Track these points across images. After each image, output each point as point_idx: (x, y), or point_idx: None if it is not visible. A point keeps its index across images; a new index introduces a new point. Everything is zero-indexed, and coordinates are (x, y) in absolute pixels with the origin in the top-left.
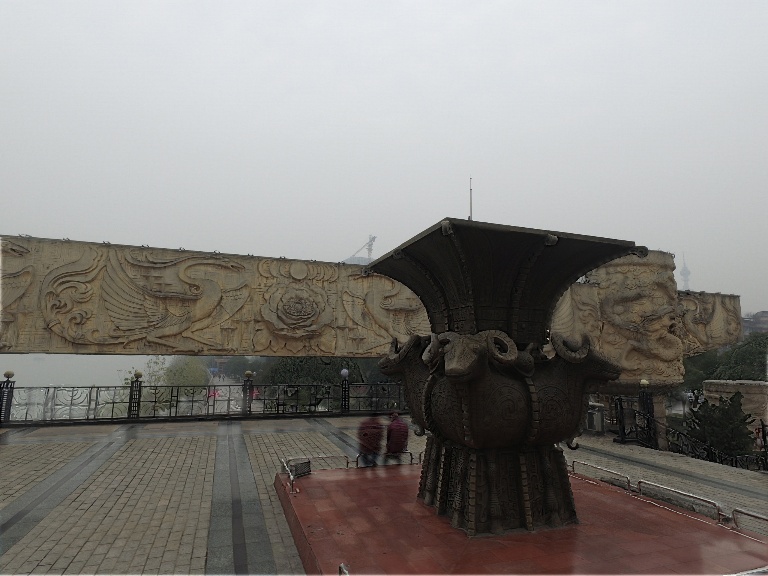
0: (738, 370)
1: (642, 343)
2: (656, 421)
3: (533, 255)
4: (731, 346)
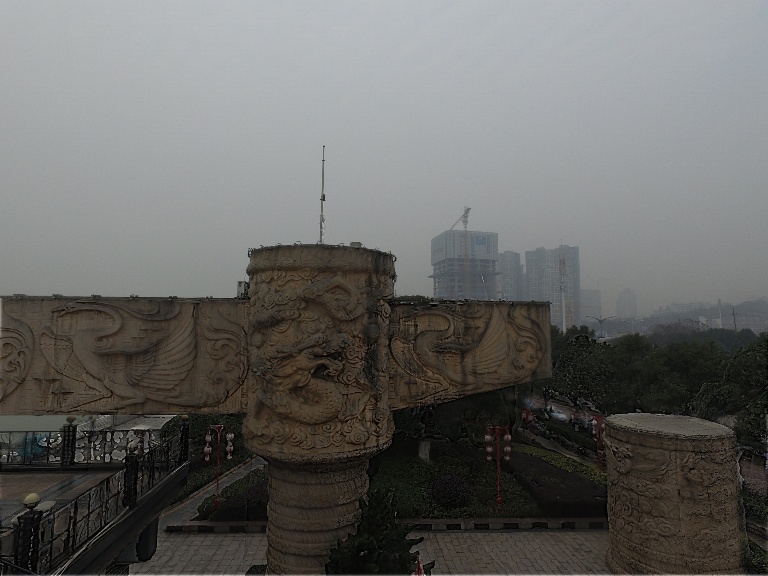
0: (724, 391)
1: (266, 395)
2: (23, 571)
3: None
4: (737, 351)
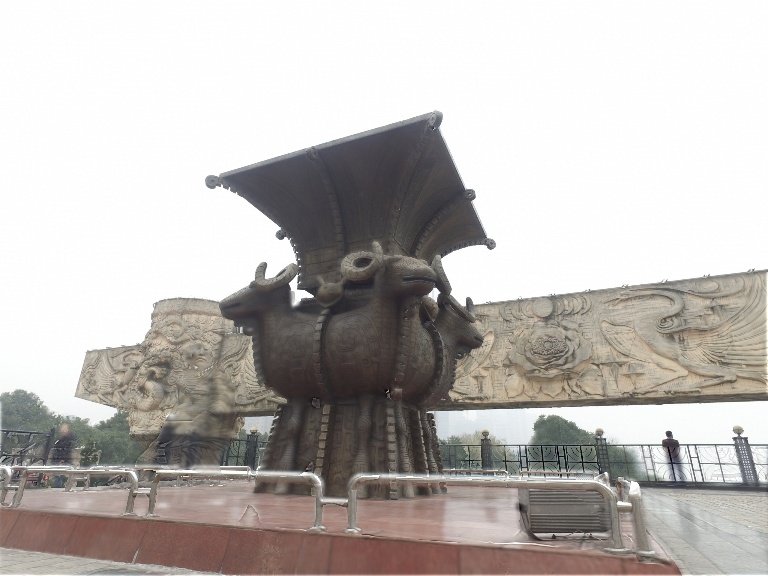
0: None
1: None
2: None
3: None
4: None
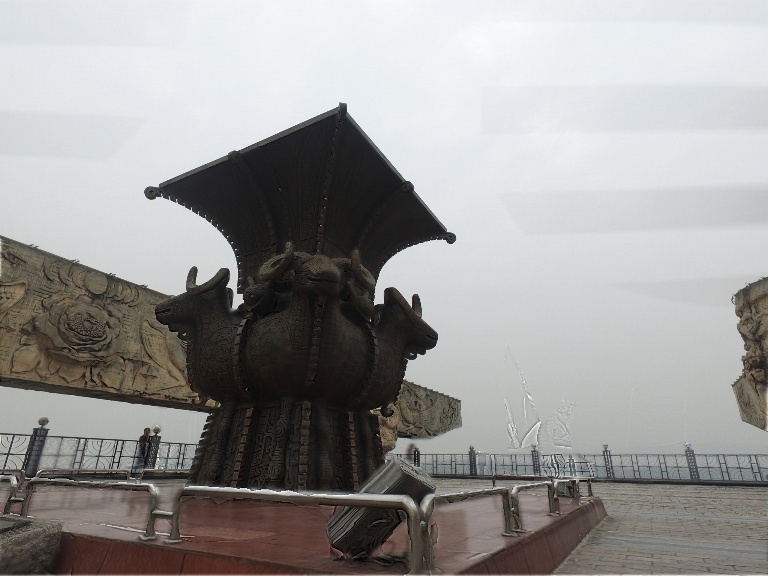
0: None
1: None
2: None
3: None
4: None
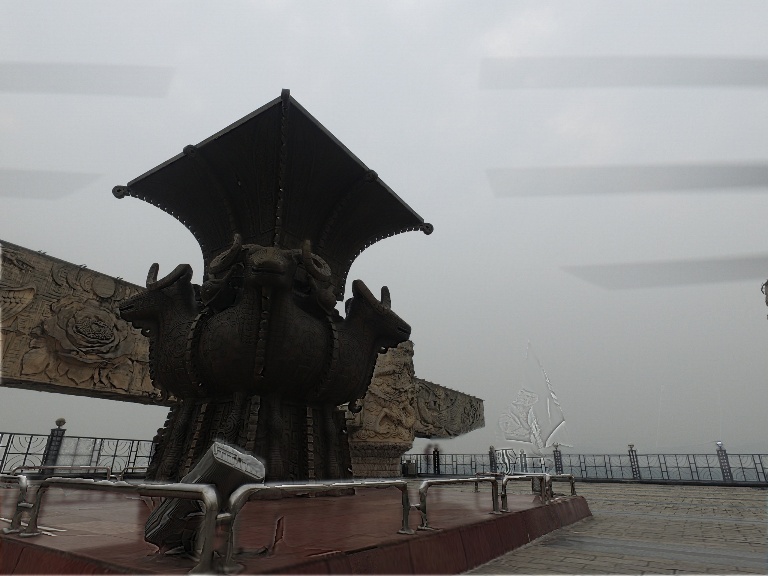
0: None
1: None
2: None
3: None
4: None
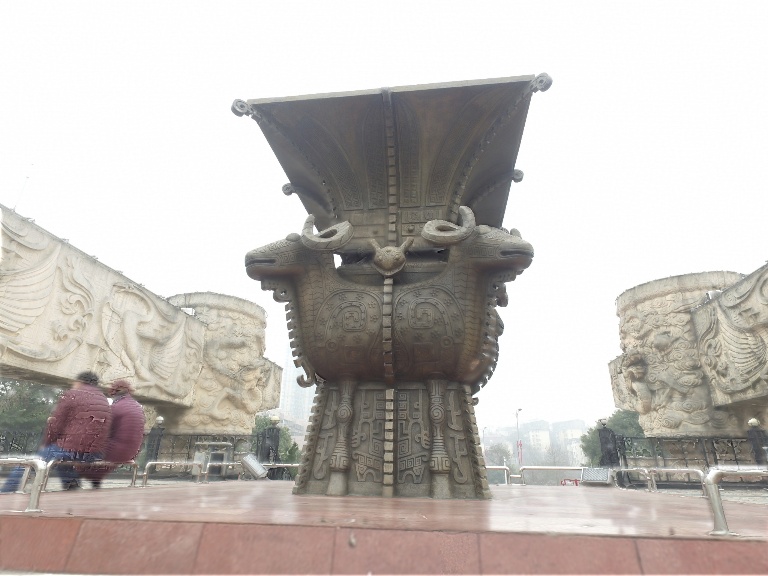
0: None
1: (237, 392)
2: None
3: (494, 184)
4: None
